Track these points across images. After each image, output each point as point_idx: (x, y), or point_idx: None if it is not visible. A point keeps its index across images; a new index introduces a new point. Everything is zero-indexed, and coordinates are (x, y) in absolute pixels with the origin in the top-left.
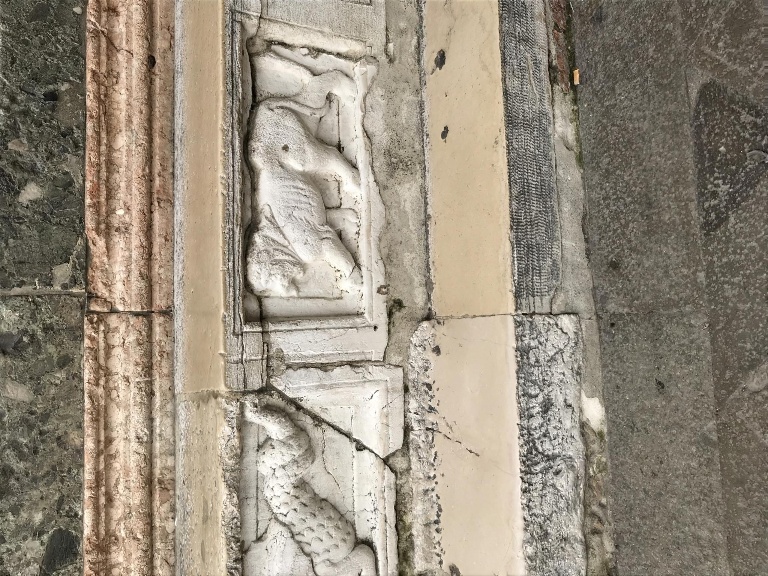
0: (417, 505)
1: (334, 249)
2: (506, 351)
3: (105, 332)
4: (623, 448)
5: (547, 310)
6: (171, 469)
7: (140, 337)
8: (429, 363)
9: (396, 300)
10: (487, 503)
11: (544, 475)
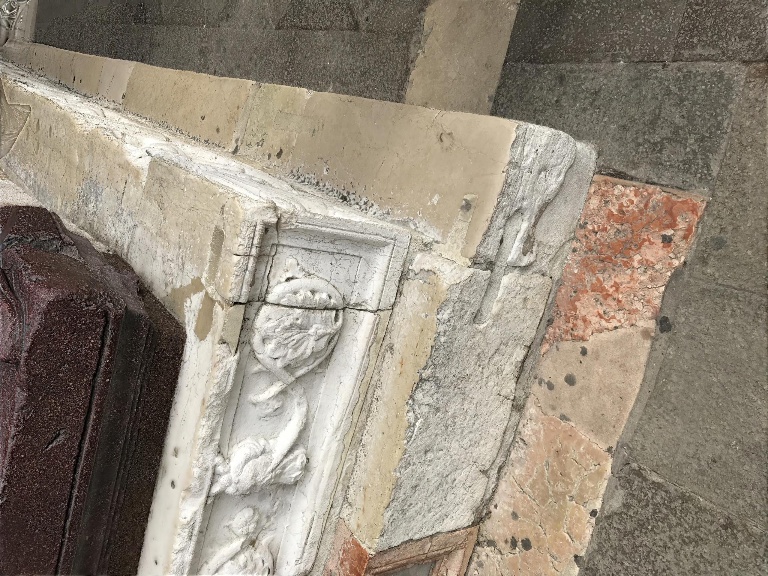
0: None
1: None
2: None
3: None
4: None
5: None
6: None
7: None
8: None
9: None
10: None
11: None
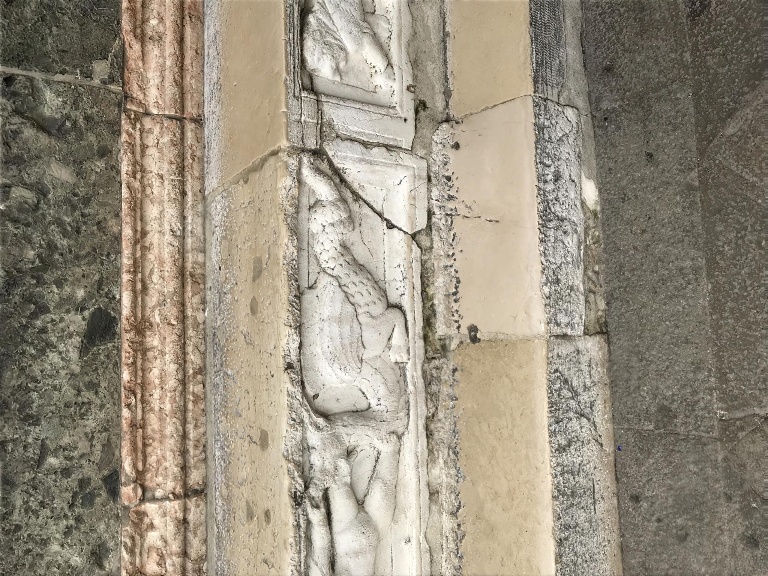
0: (438, 278)
1: (373, 43)
2: (526, 127)
3: (141, 130)
4: (614, 218)
5: (556, 99)
6: (201, 265)
7: (174, 138)
8: (448, 158)
9: (421, 100)
10: (507, 259)
11: (555, 231)
